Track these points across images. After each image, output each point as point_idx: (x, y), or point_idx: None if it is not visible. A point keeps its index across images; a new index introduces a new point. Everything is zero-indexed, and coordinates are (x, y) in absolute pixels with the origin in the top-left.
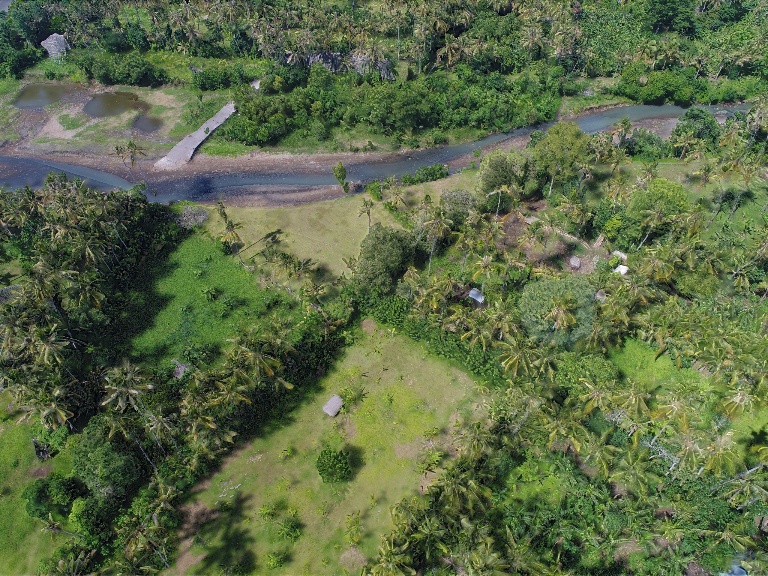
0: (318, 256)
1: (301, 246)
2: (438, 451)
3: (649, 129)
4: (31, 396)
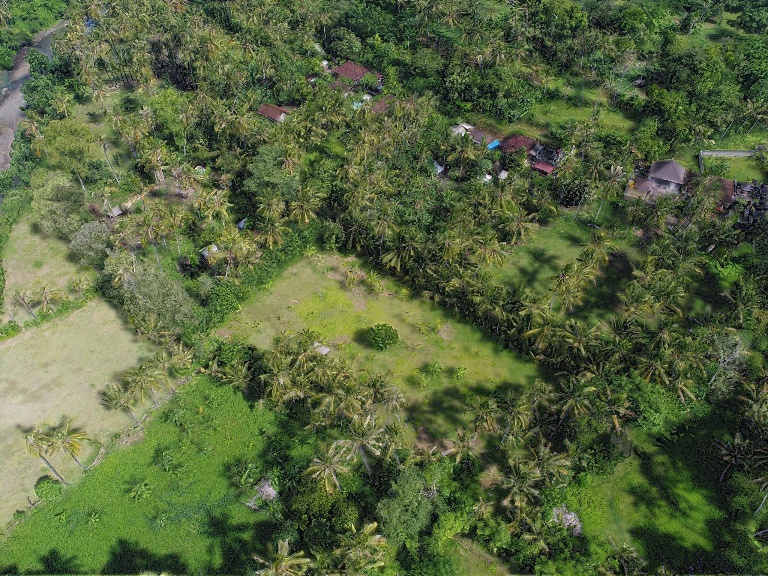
0: (101, 386)
1: (75, 406)
2: (360, 286)
3: (4, 131)
4: (354, 567)
